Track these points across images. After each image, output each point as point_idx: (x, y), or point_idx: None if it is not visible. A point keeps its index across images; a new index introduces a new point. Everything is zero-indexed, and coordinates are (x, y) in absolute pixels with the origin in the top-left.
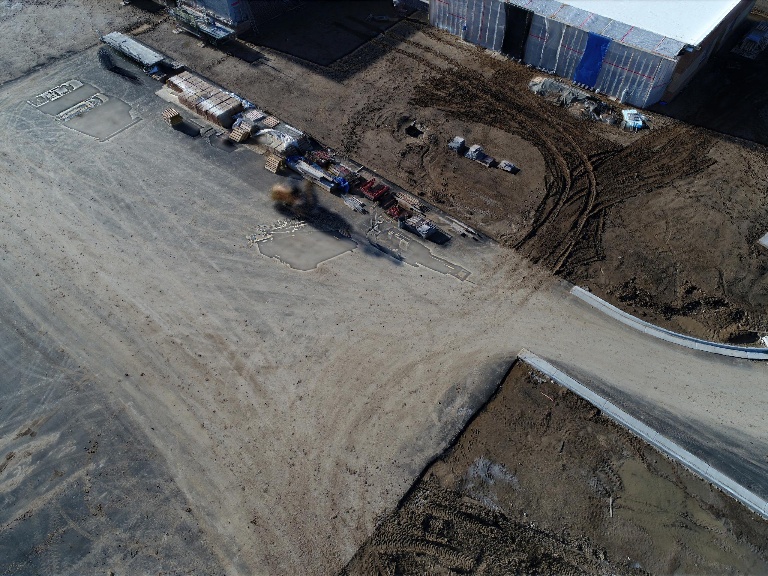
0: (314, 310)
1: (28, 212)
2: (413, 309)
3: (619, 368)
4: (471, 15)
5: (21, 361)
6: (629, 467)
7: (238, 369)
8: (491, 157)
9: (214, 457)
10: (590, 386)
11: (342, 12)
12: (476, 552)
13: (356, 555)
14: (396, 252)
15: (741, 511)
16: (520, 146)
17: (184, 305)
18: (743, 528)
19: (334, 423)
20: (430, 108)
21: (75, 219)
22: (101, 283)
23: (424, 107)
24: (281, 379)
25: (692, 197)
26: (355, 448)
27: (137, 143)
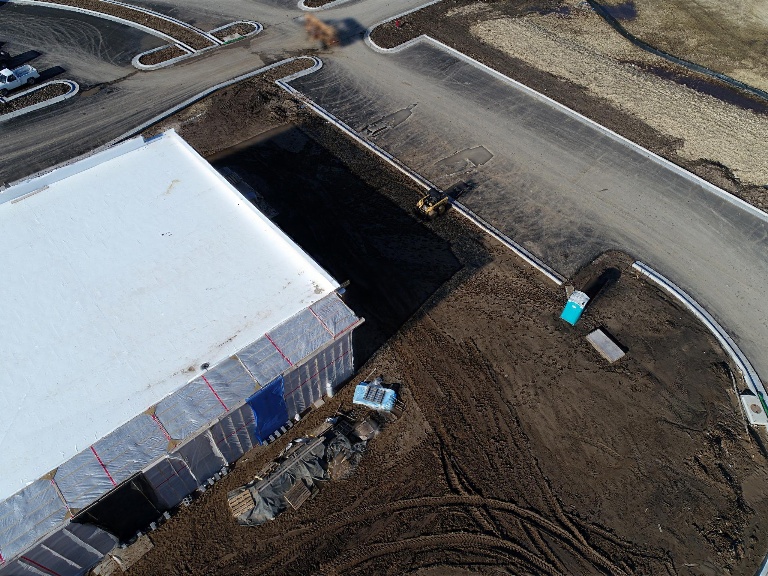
0: None
1: None
2: None
3: None
4: None
5: None
6: None
7: None
8: None
9: None
10: None
11: None
12: None
13: None
14: None
15: None
16: None
17: None
18: None
19: None
20: None
21: None
22: None
23: None
24: None
25: (537, 393)
26: None
27: None
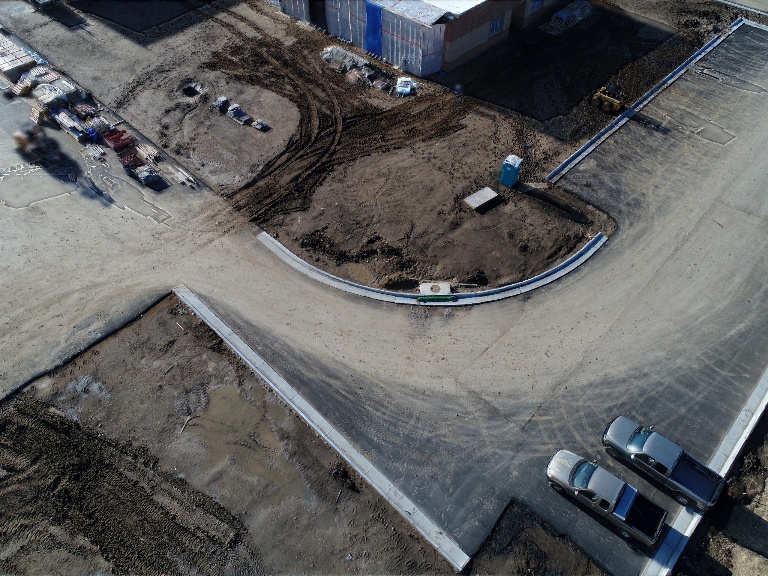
0: (5, 242)
1: None
2: (98, 245)
3: (263, 305)
4: None
5: None
6: (223, 391)
7: None
8: (248, 116)
9: None
10: (226, 319)
11: None
12: (34, 454)
13: None
14: (104, 194)
15: (306, 434)
16: (284, 107)
17: None
18: (299, 449)
19: None
20: (217, 71)
21: None
22: None
23: (212, 70)
24: None
25: (424, 158)
26: None
27: None
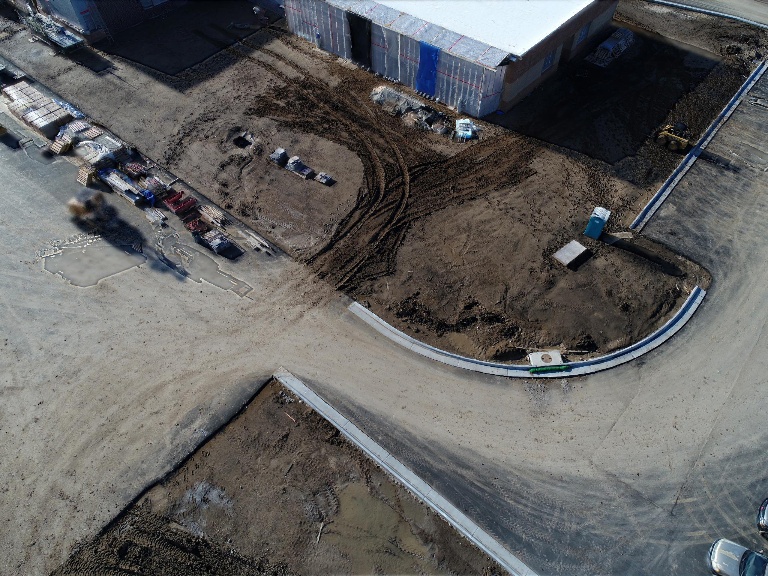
0: (80, 328)
1: None
2: (182, 326)
3: (372, 387)
4: (321, 23)
5: None
6: (351, 490)
7: None
8: (310, 169)
9: None
10: (337, 406)
11: (206, 20)
12: None
13: None
14: (178, 268)
15: (451, 535)
16: (344, 157)
17: None
18: (447, 553)
19: (62, 446)
20: (265, 118)
21: None
22: None
23: (259, 117)
24: (23, 400)
25: (501, 209)
26: (76, 472)
27: None
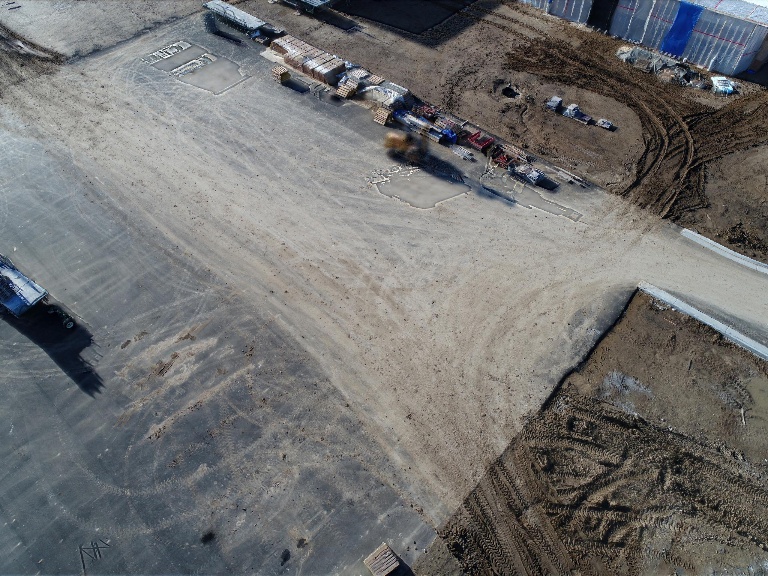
0: (438, 242)
1: (158, 153)
2: (532, 244)
3: (736, 300)
4: None
5: (172, 277)
6: (756, 384)
7: (375, 290)
8: (589, 116)
9: (364, 362)
10: (710, 314)
11: None
12: (621, 449)
13: (508, 448)
14: (511, 194)
15: None
16: (615, 107)
17: (316, 235)
18: None
19: (472, 337)
20: (523, 72)
21: (202, 160)
22: (235, 214)
23: (517, 71)
24: (416, 299)
25: None
26: (494, 359)
27: (250, 97)
